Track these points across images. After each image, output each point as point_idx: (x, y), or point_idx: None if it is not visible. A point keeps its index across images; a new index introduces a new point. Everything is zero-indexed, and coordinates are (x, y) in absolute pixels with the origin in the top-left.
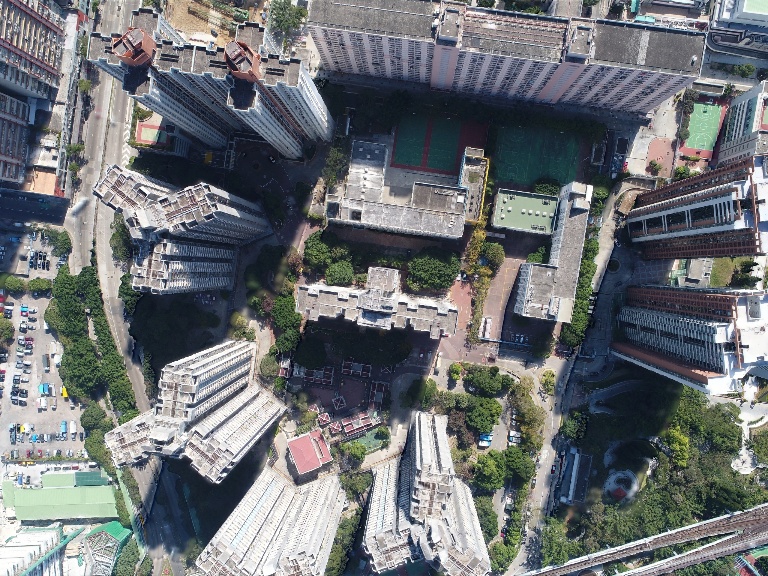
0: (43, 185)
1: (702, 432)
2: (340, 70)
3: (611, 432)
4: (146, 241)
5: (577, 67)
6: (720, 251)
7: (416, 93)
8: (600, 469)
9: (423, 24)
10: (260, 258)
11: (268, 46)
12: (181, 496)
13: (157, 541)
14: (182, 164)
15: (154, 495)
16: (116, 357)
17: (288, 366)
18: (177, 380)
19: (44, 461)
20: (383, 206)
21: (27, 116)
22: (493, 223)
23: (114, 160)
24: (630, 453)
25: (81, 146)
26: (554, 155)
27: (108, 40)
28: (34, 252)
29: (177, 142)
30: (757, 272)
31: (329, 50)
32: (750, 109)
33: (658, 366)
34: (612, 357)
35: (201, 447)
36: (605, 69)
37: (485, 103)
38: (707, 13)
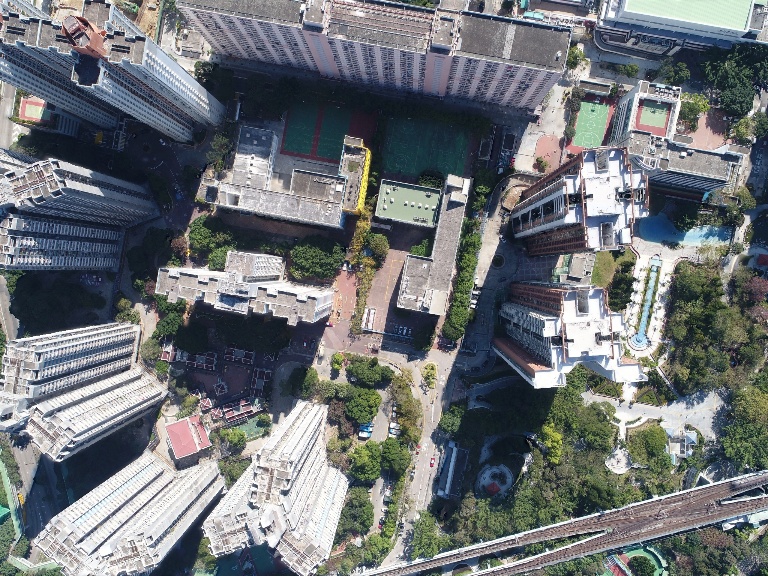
0: None
1: (576, 430)
2: (231, 54)
3: (487, 427)
4: None
5: (443, 58)
6: (566, 246)
7: (308, 81)
8: (473, 463)
9: (292, 9)
10: (143, 240)
11: (119, 23)
12: (59, 477)
13: (36, 521)
14: (69, 143)
15: (35, 475)
16: None
17: (170, 350)
18: (20, 356)
19: None
20: (261, 192)
21: None
22: (375, 213)
23: (4, 137)
24: (502, 448)
25: None
26: (443, 148)
27: None
28: None
29: (61, 120)
30: (639, 273)
31: (210, 33)
32: (629, 109)
33: (512, 360)
34: (494, 352)
35: (42, 424)
36: (472, 61)
37: (376, 93)
38: (597, 12)
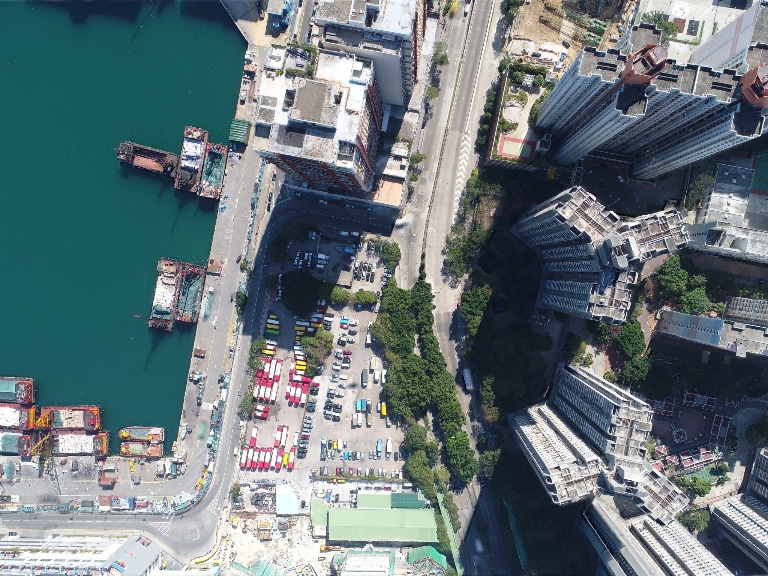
0: (388, 195)
1: None
2: None
3: None
4: (610, 268)
5: None
6: None
7: None
8: None
9: None
10: None
11: None
12: (506, 524)
13: (470, 568)
14: (534, 180)
15: (470, 521)
16: (449, 377)
17: None
18: (633, 416)
19: (357, 480)
20: None
21: (381, 123)
22: None
23: (449, 171)
24: None
25: (424, 156)
26: None
27: (602, 55)
28: (359, 263)
29: None
30: None
31: None
32: None
33: None
34: None
35: (653, 488)
36: None
37: None
38: None
